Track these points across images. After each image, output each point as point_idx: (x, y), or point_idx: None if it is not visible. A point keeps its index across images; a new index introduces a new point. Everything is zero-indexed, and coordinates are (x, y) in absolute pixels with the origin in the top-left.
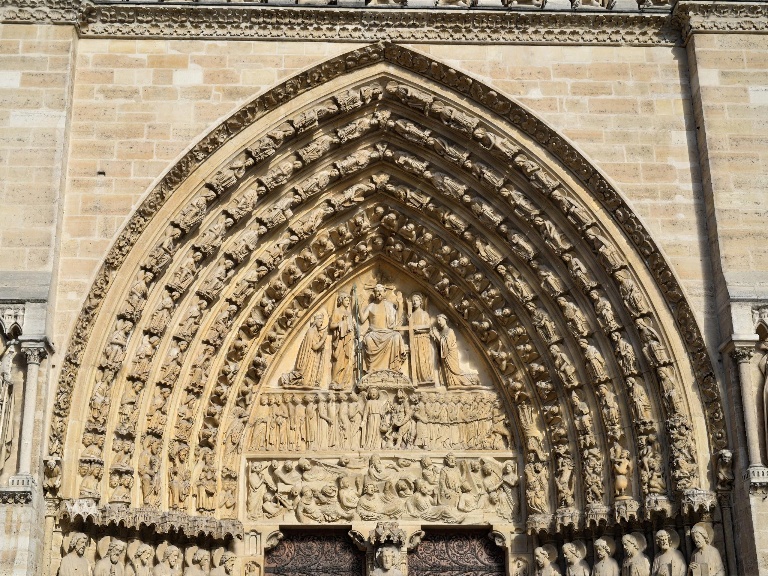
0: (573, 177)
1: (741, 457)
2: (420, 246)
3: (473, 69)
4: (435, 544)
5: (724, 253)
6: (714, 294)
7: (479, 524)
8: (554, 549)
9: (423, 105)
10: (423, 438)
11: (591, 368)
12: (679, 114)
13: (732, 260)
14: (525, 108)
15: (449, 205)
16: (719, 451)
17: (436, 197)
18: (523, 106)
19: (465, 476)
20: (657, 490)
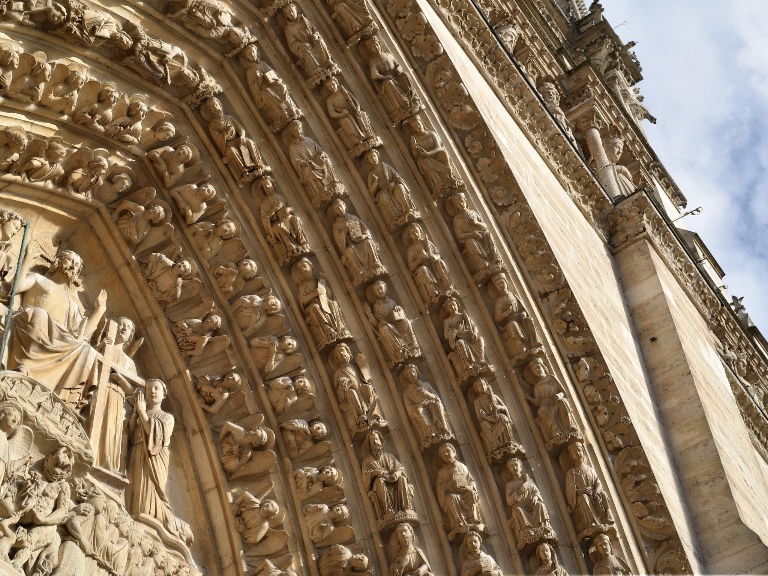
0: (523, 277)
1: None
2: (192, 238)
3: (444, 42)
4: None
5: (736, 499)
6: (702, 559)
7: None
8: None
9: (363, 22)
10: None
11: None
12: (623, 312)
13: None
14: (496, 140)
15: (292, 202)
16: None
17: (277, 176)
18: (494, 136)
19: None
20: None
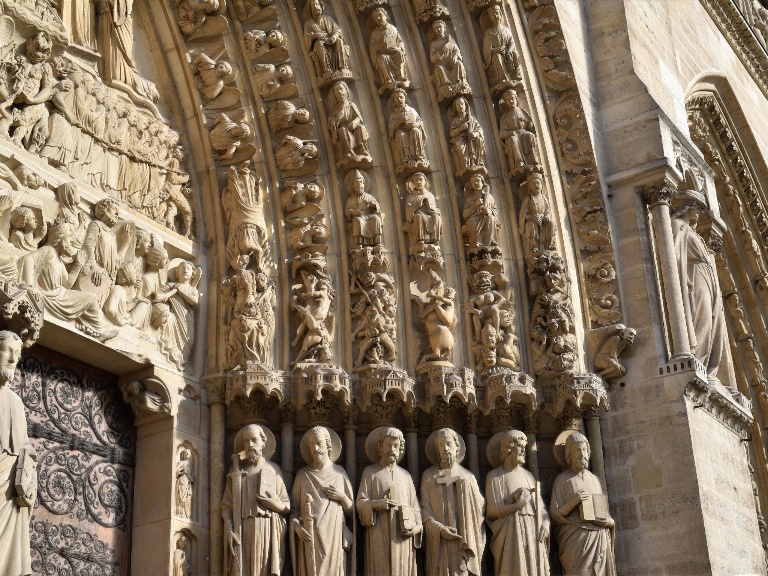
0: None
1: (657, 339)
2: None
3: None
4: (25, 373)
5: (633, 50)
6: (597, 104)
7: (131, 355)
8: (272, 435)
9: None
10: (63, 148)
11: (410, 140)
12: None
13: (639, 65)
14: None
15: None
16: (615, 324)
17: None
18: None
19: (124, 254)
20: (513, 363)
